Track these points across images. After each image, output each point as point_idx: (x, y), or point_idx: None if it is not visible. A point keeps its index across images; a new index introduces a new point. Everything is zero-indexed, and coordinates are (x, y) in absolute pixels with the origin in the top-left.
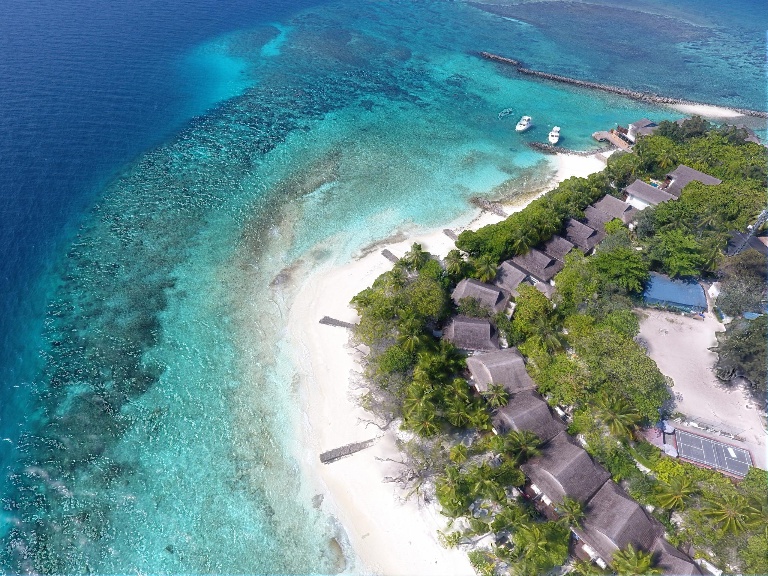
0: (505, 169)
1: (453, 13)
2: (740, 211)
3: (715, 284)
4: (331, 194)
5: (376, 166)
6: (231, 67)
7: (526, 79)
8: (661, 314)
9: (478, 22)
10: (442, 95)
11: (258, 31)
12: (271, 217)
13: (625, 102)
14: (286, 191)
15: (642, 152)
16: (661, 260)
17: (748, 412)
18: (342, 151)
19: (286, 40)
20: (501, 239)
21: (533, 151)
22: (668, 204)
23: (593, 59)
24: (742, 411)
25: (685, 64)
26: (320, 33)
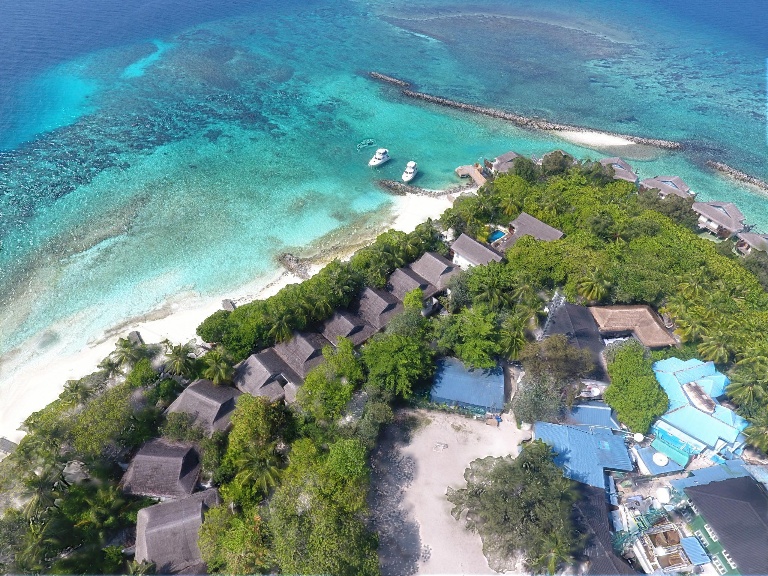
0: (338, 215)
1: (360, 28)
2: (567, 276)
3: (521, 375)
4: (108, 252)
5: (184, 213)
6: (79, 91)
7: (408, 103)
8: (448, 418)
9: (383, 38)
10: (306, 122)
11: (132, 49)
12: (14, 287)
13: (508, 129)
14: (54, 249)
15: (485, 196)
16: (451, 348)
17: (510, 575)
18: (152, 194)
19: (159, 59)
20: (250, 325)
21: (381, 191)
22: (485, 268)
23: (491, 79)
24: (502, 574)
25: (589, 84)
26: (201, 51)
